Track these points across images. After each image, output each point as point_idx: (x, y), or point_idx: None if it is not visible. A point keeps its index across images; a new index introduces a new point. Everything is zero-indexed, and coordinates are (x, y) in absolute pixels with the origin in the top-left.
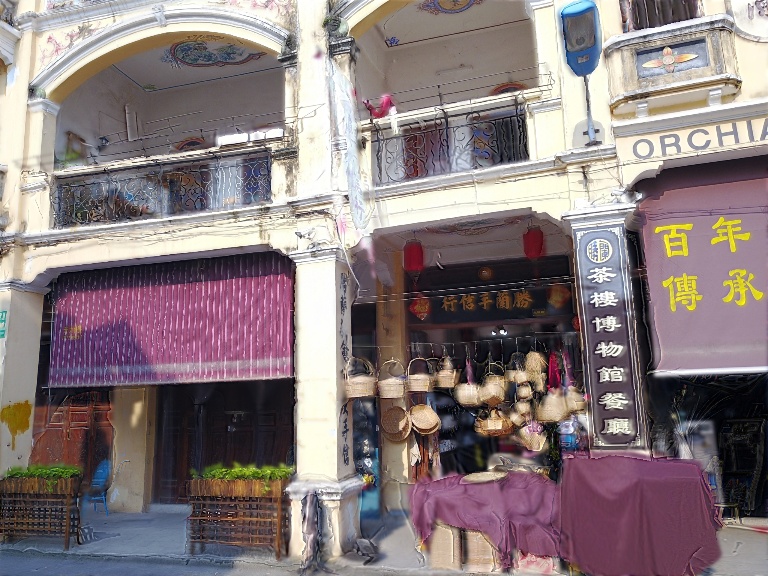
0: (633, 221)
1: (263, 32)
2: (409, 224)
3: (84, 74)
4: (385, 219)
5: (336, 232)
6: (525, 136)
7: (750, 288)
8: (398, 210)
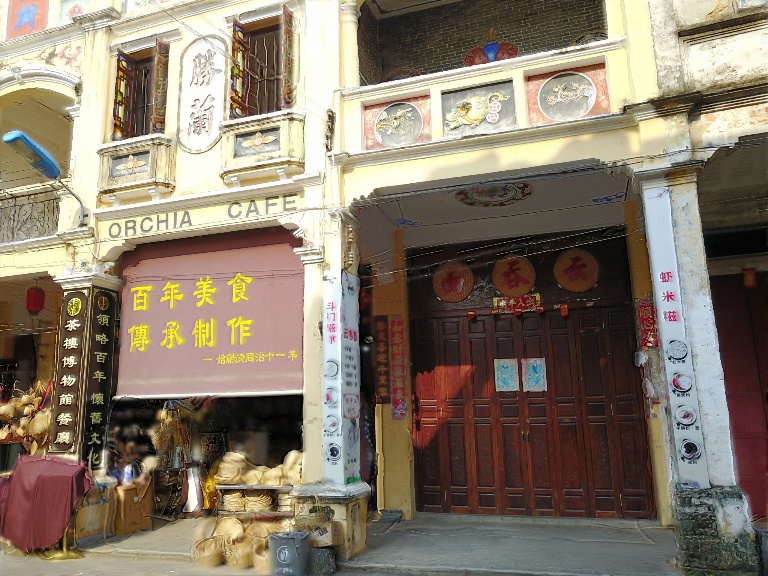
0: (117, 283)
1: None
2: None
3: None
4: None
5: None
6: (58, 215)
7: (175, 336)
8: None
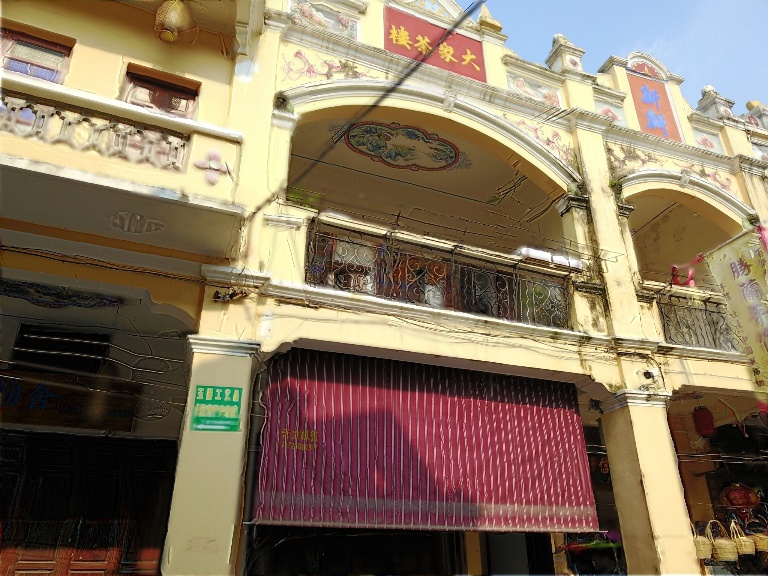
0: None
1: (551, 166)
2: (708, 387)
3: (340, 113)
4: (691, 377)
5: (661, 380)
6: None
7: None
8: (699, 372)
